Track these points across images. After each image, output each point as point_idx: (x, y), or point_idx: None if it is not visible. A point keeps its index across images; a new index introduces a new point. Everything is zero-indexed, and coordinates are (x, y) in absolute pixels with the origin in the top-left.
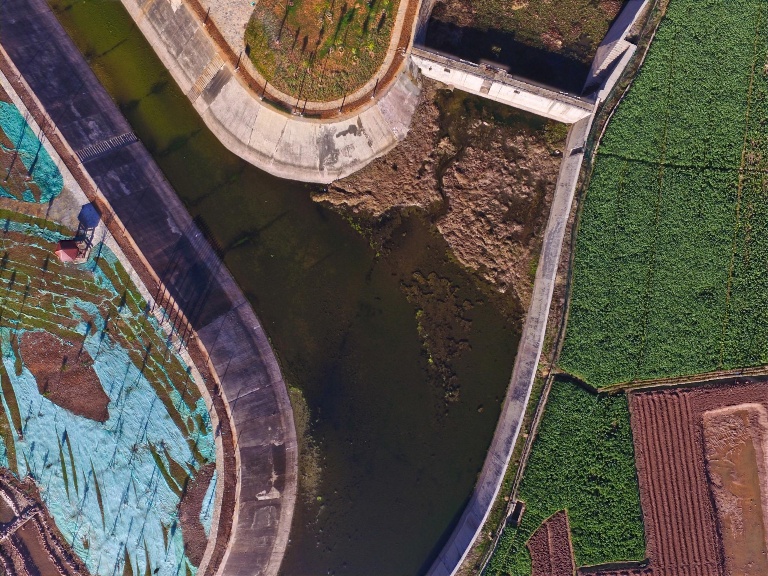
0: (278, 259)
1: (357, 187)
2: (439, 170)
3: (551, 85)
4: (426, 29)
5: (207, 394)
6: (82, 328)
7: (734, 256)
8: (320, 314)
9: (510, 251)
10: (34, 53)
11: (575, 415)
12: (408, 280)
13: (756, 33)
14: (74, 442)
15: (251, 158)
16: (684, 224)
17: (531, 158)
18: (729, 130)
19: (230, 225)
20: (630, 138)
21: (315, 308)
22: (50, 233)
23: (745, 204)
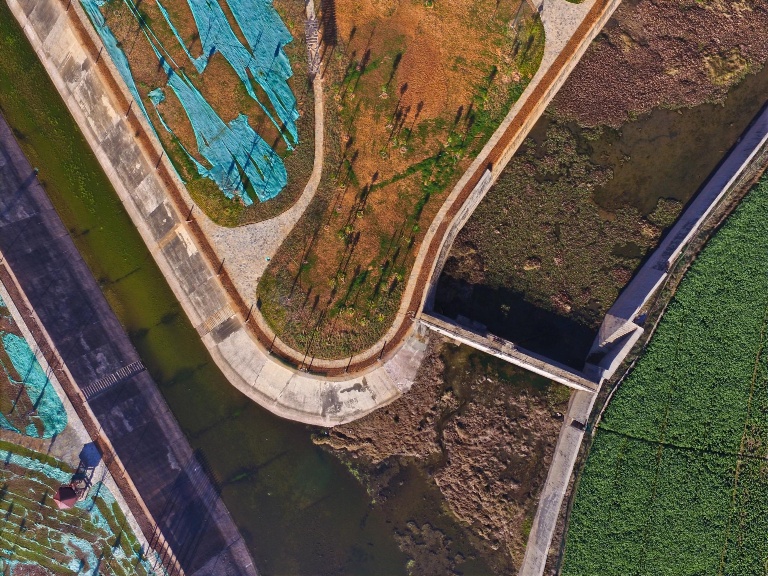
0: (275, 497)
1: (358, 434)
2: (440, 422)
3: (557, 347)
4: (437, 283)
5: None
6: (75, 565)
7: (727, 542)
8: (312, 555)
9: (505, 509)
10: (48, 284)
11: None
12: (402, 528)
13: (763, 321)
14: None
15: (255, 397)
16: (679, 507)
17: (532, 418)
18: (730, 417)
19: (229, 460)
20: (631, 417)
21: (308, 549)
22: (50, 468)
23: (741, 490)
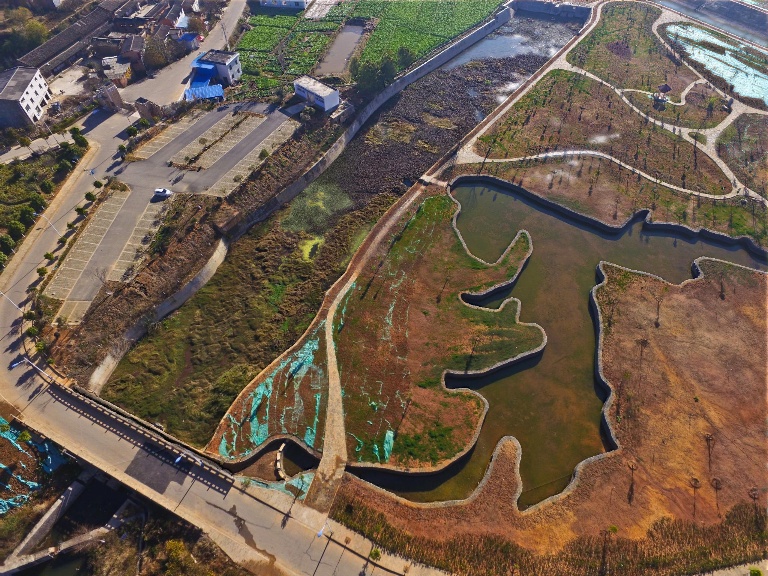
0: None
1: None
2: None
3: None
4: None
5: None
6: None
7: None
8: None
9: None
10: None
11: None
12: None
13: None
14: None
15: None
16: None
17: None
18: None
19: None
20: None
21: None
22: None
23: None
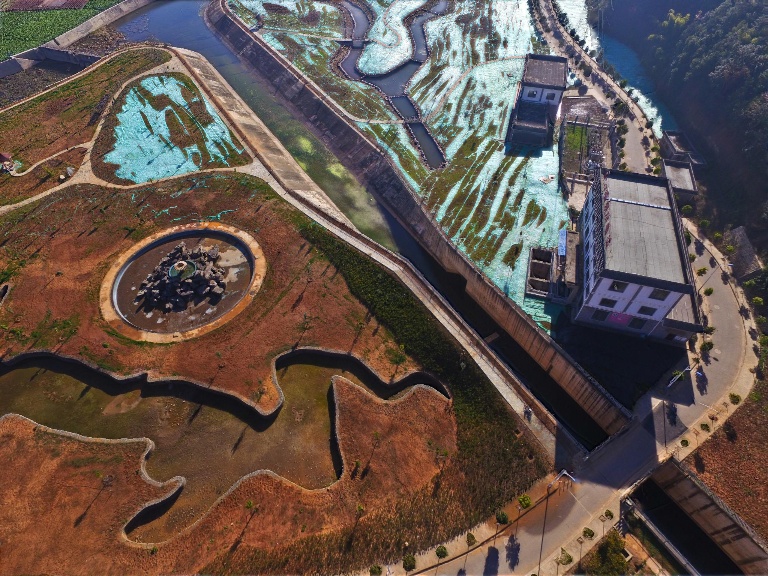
0: None
1: None
2: None
3: None
4: None
5: (226, 5)
6: (267, 15)
7: None
8: None
9: None
10: None
11: (103, 4)
12: None
13: None
14: (278, 1)
15: None
16: None
17: None
18: None
19: None
20: None
21: None
22: (271, 28)
23: None
